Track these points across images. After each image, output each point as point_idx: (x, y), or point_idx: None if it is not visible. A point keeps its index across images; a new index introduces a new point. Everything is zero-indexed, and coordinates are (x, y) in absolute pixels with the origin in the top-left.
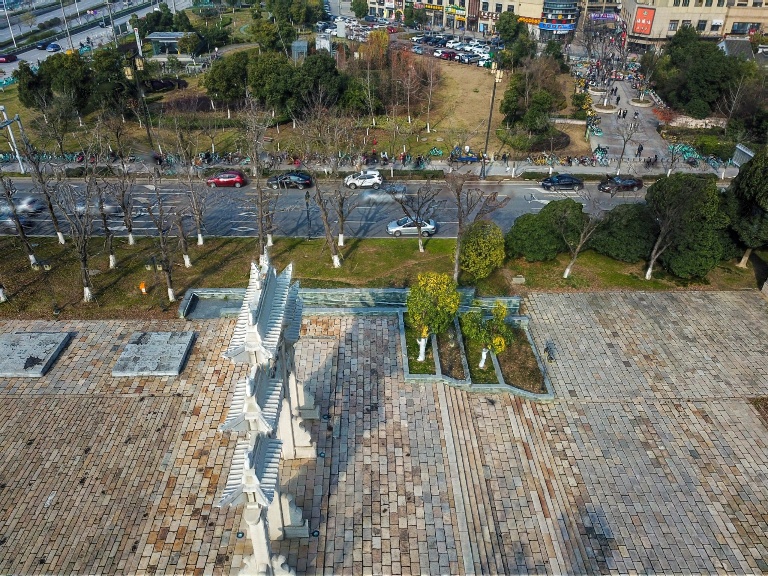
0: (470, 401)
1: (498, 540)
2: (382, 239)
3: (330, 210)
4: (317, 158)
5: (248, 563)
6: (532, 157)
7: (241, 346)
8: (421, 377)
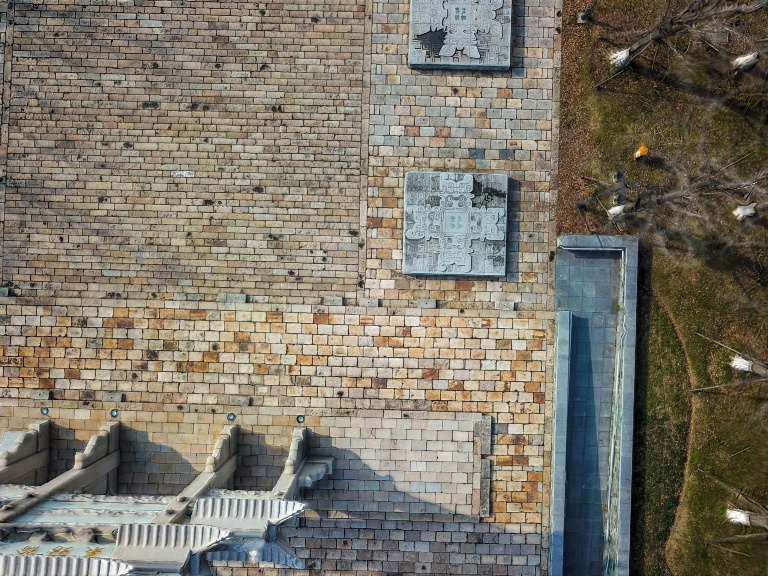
0: None
1: None
2: None
3: None
4: None
5: None
6: None
7: None
8: None
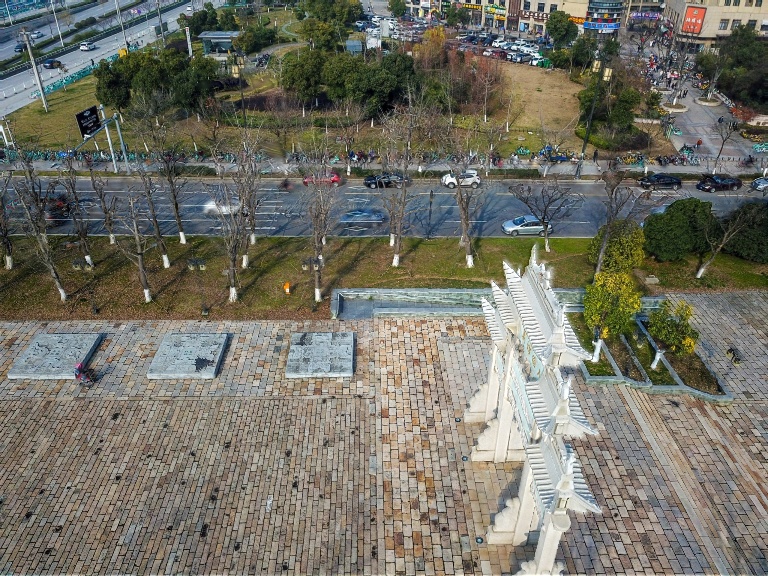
0: (653, 403)
1: (736, 545)
2: (501, 239)
3: (436, 209)
4: (446, 157)
5: (527, 570)
6: (622, 156)
7: (548, 348)
8: (603, 378)
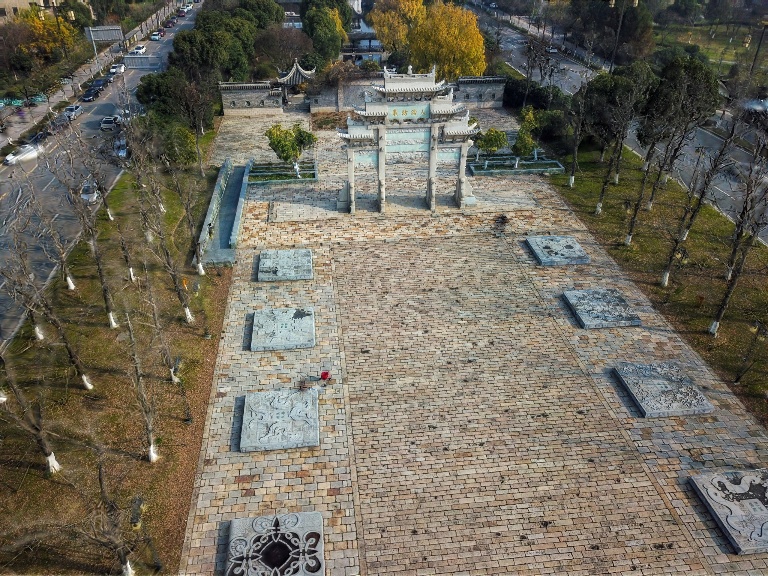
0: None
1: None
2: None
3: (8, 237)
4: None
5: (464, 181)
6: None
7: None
8: None
